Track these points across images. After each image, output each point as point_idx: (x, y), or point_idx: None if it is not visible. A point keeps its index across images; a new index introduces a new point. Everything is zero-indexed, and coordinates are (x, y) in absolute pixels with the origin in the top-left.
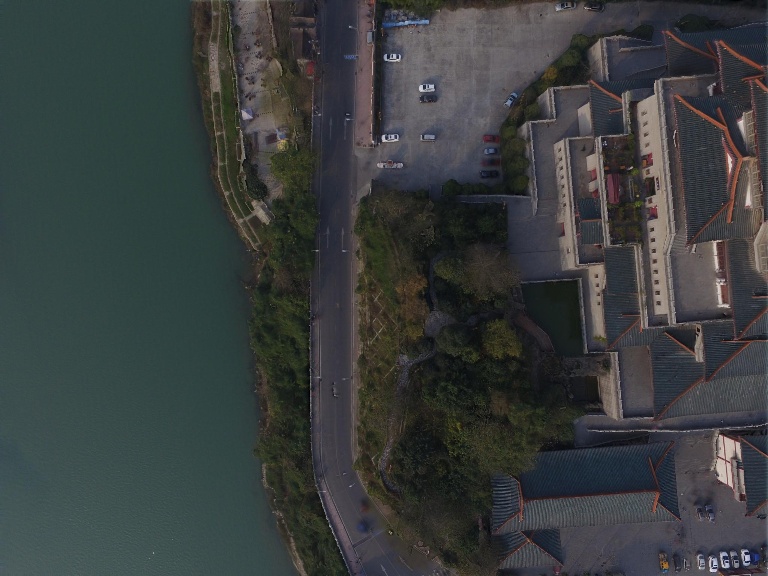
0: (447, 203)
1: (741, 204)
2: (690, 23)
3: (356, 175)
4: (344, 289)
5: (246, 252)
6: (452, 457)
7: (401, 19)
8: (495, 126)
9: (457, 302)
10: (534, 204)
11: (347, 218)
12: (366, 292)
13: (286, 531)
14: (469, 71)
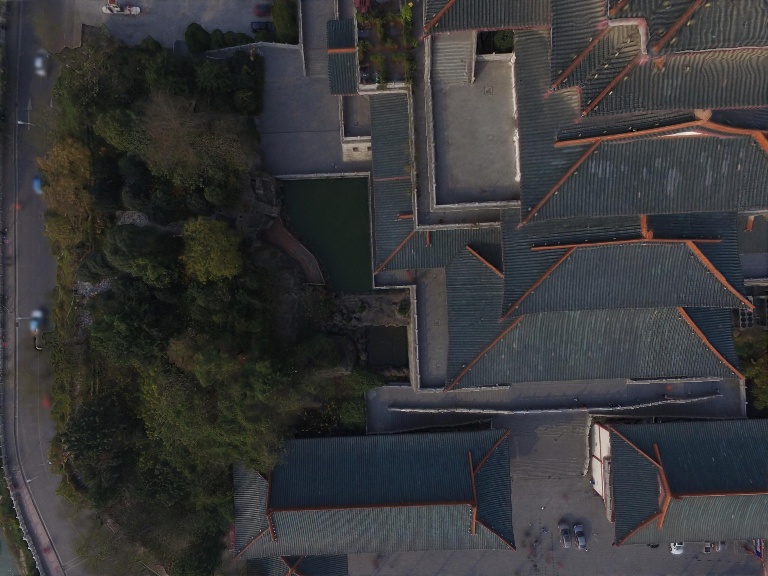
0: None
1: None
2: None
3: (72, 23)
4: None
5: None
6: (153, 440)
7: None
8: None
9: (147, 191)
10: (302, 56)
11: None
12: None
13: None
14: None
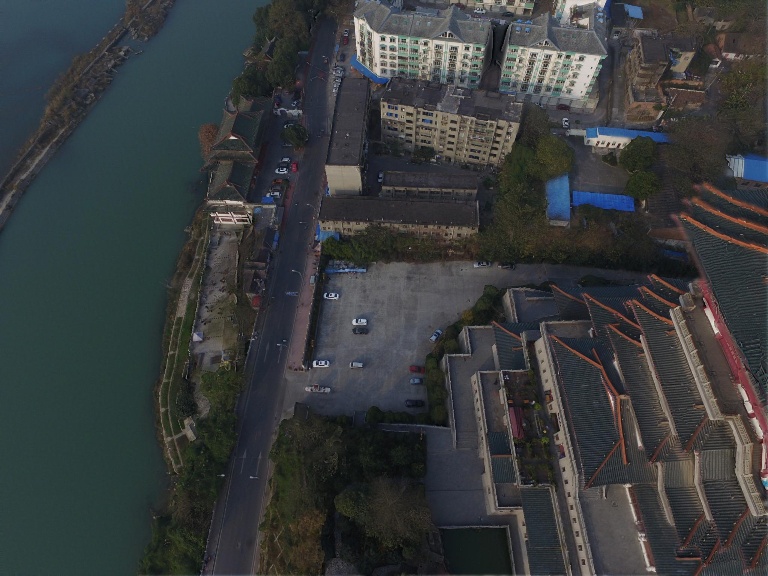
0: (367, 430)
1: (633, 444)
2: (588, 281)
3: (283, 397)
4: (250, 524)
5: (165, 475)
6: None
7: (342, 267)
8: (421, 358)
9: (360, 547)
10: (453, 436)
11: (267, 441)
12: (267, 529)
13: None
14: (399, 310)
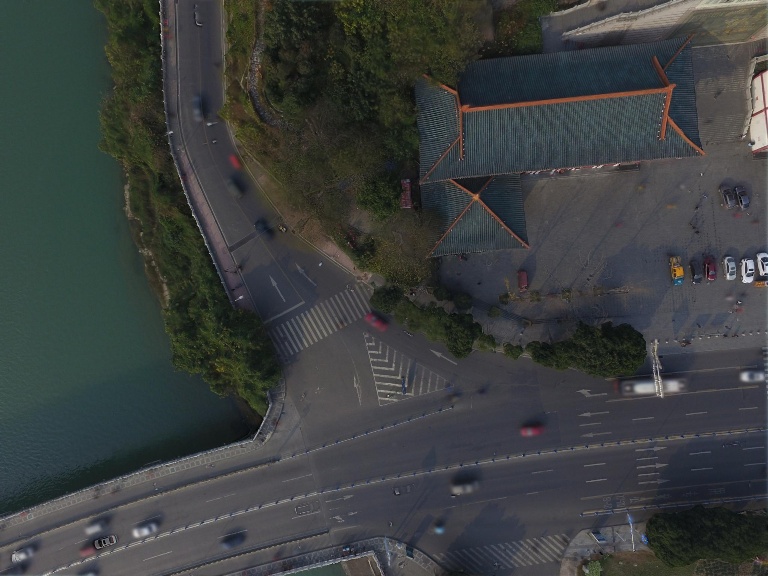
0: None
1: None
2: None
3: None
4: None
5: None
6: (349, 35)
7: None
8: None
9: None
10: None
11: None
12: None
13: (157, 276)
14: None
